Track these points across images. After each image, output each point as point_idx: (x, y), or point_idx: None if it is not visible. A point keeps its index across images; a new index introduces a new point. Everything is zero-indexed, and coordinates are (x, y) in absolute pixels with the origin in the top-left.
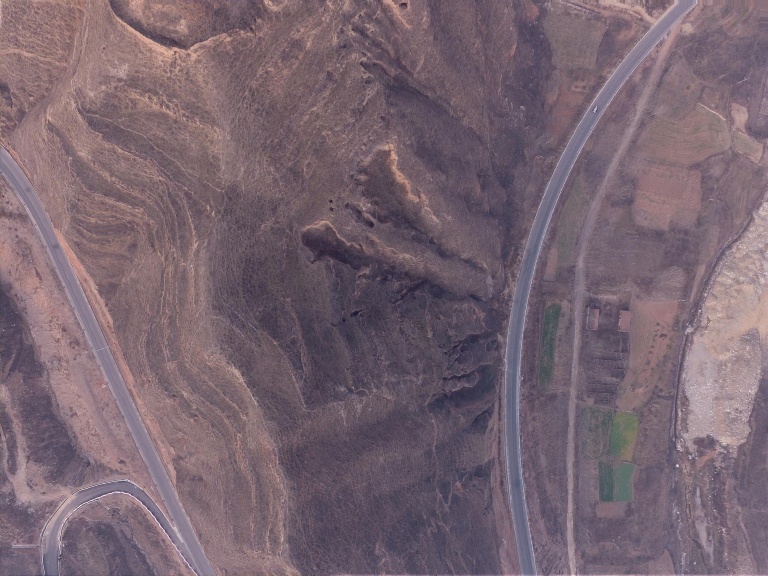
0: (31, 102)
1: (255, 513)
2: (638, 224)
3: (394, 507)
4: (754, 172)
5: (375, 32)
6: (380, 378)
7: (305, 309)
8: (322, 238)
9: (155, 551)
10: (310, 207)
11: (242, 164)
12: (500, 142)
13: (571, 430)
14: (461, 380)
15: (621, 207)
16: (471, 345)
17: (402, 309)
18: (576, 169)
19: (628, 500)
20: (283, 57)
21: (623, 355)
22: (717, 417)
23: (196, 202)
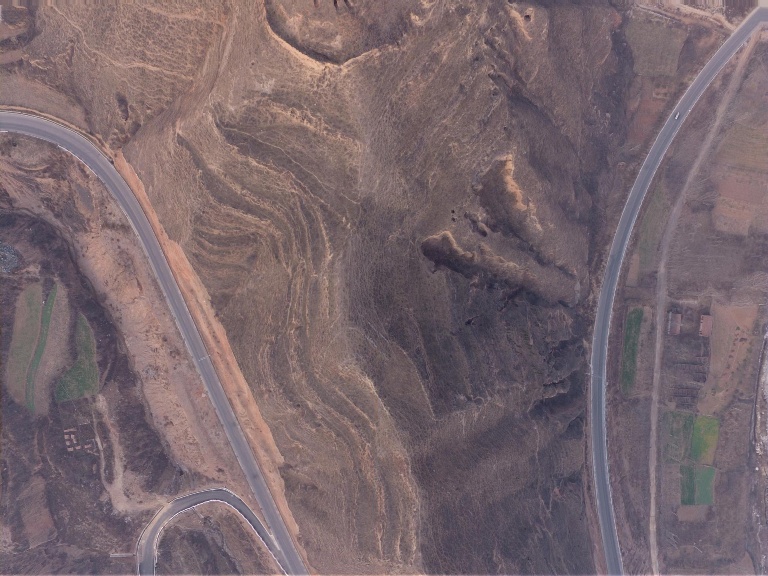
0: (148, 115)
1: (383, 522)
2: (718, 229)
3: (505, 514)
4: None
5: (501, 44)
6: (493, 386)
7: (426, 318)
8: (437, 248)
9: (248, 559)
10: (433, 218)
11: (378, 176)
12: (587, 149)
13: (653, 434)
14: (557, 386)
15: (701, 212)
16: (562, 351)
17: (506, 317)
18: (658, 175)
19: (709, 503)
20: (423, 71)
21: (704, 359)
22: None
23: (331, 214)
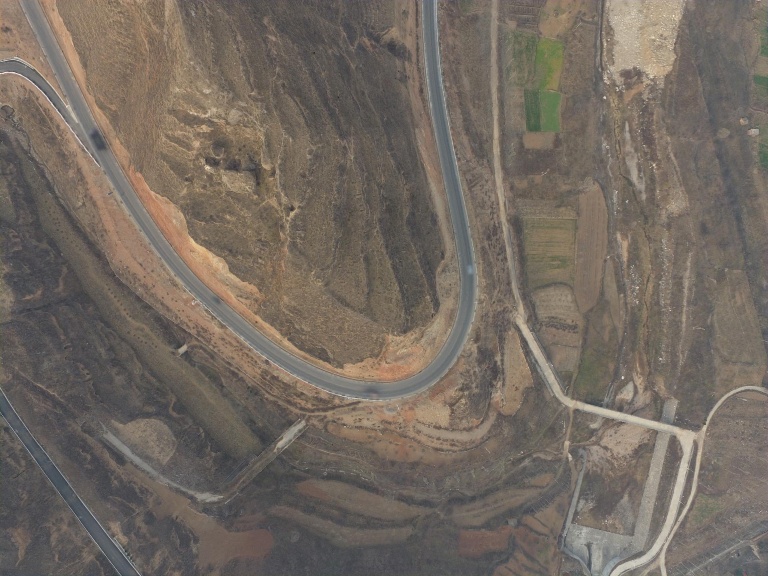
0: None
1: None
2: None
3: (288, 5)
4: None
5: None
6: None
7: None
8: None
9: (51, 150)
10: None
11: None
12: None
13: (494, 53)
14: None
15: None
16: None
17: None
18: None
19: (556, 131)
20: None
21: None
22: (642, 47)
23: None
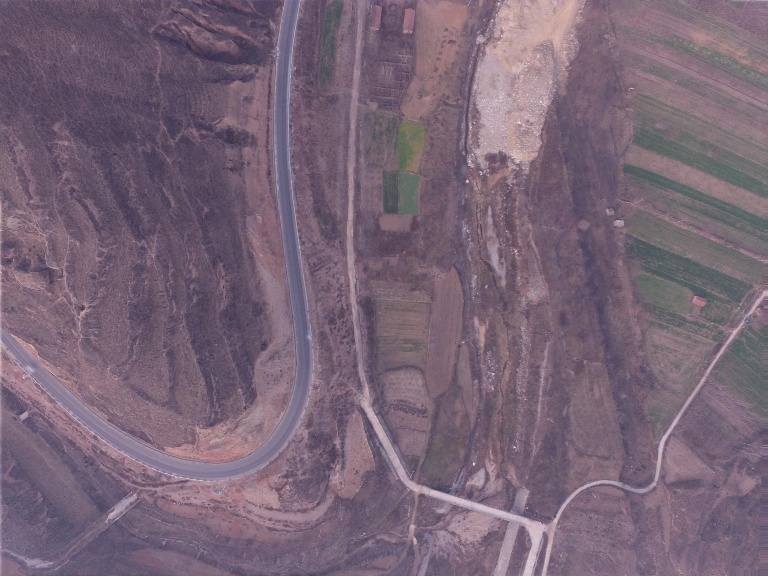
0: None
1: None
2: None
3: (92, 106)
4: None
5: None
6: None
7: None
8: None
9: None
10: None
11: None
12: None
13: (352, 134)
14: None
15: None
16: None
17: None
18: None
19: (414, 213)
20: None
21: (408, 59)
22: (509, 131)
23: None
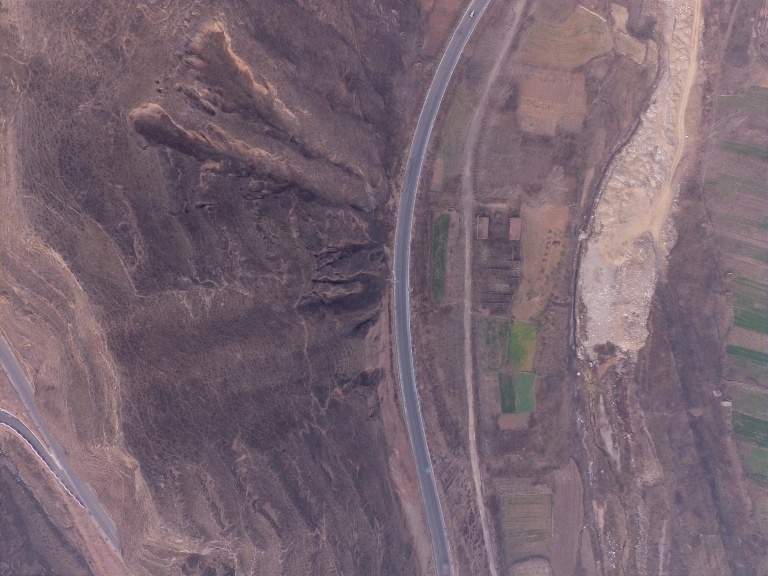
0: None
1: None
2: (524, 130)
3: (257, 406)
4: (639, 73)
5: None
6: (232, 272)
7: (140, 197)
8: (160, 128)
9: (38, 483)
10: (135, 89)
11: (44, 34)
12: (372, 47)
13: (468, 342)
14: (337, 285)
15: (506, 114)
16: (351, 254)
17: (261, 208)
18: (457, 76)
19: (530, 411)
20: None
21: (516, 264)
22: (615, 323)
23: None
